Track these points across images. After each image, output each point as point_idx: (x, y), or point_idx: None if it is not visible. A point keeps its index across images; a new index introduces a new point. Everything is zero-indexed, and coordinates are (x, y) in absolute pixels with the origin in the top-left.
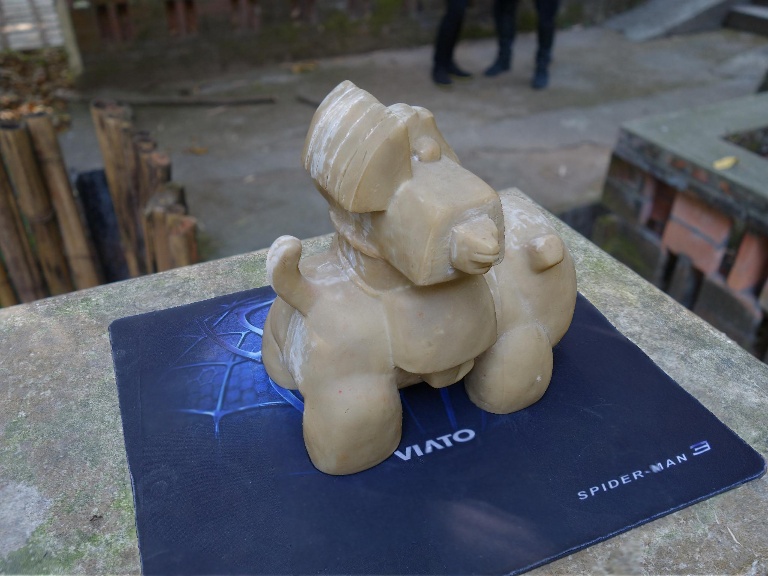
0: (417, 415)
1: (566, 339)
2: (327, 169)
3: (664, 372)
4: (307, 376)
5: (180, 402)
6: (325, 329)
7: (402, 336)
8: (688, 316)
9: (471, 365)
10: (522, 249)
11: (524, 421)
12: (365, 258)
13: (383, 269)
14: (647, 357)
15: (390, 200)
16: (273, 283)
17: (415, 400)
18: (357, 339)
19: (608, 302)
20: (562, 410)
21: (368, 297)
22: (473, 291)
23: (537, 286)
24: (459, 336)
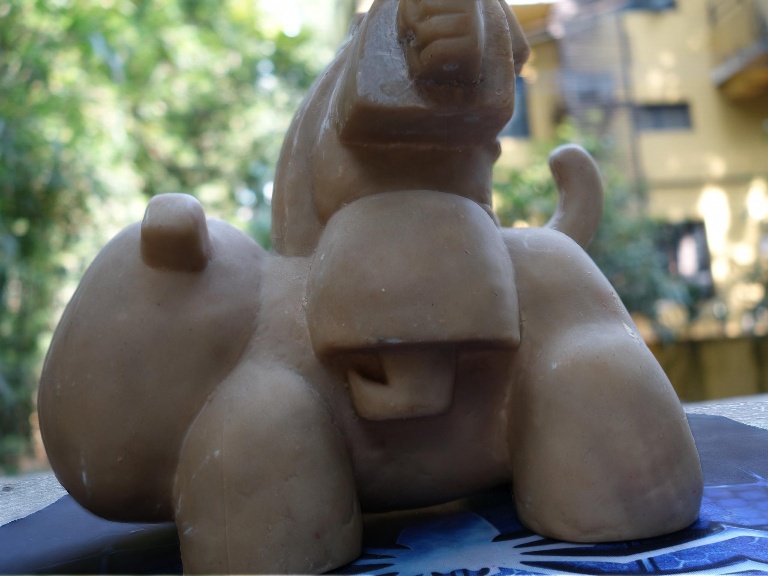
0: None
1: (71, 541)
2: None
3: (36, 512)
4: None
5: None
6: None
7: None
8: None
9: None
10: None
11: None
12: None
13: None
14: (17, 521)
15: None
16: None
17: None
18: None
19: None
20: None
21: None
22: None
23: None
24: None
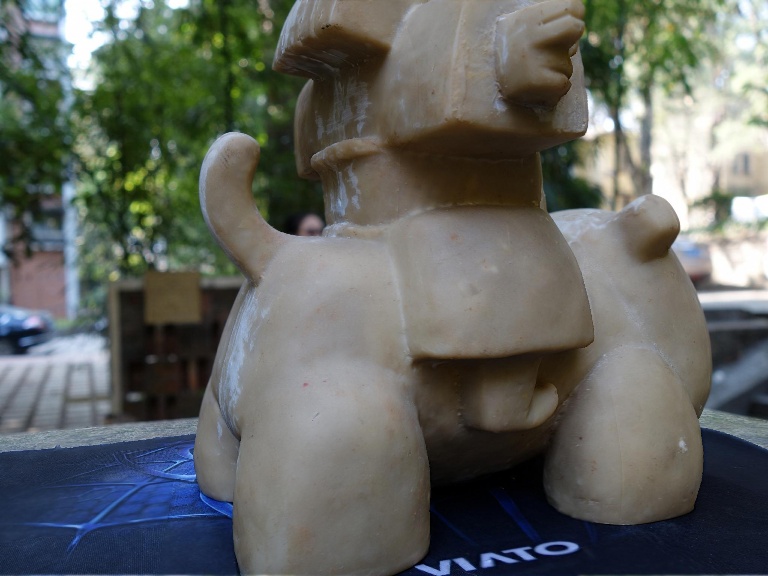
0: (460, 526)
1: (704, 464)
2: (302, 10)
3: None
4: (248, 378)
5: (30, 516)
6: (286, 278)
7: (422, 278)
8: None
9: (553, 399)
10: (610, 225)
11: (672, 532)
12: (359, 168)
13: (388, 173)
14: None
15: (395, 29)
16: (206, 203)
17: (456, 512)
18: (341, 287)
19: (752, 441)
20: (740, 522)
21: (364, 241)
22: (542, 224)
23: (645, 283)
24: (526, 286)
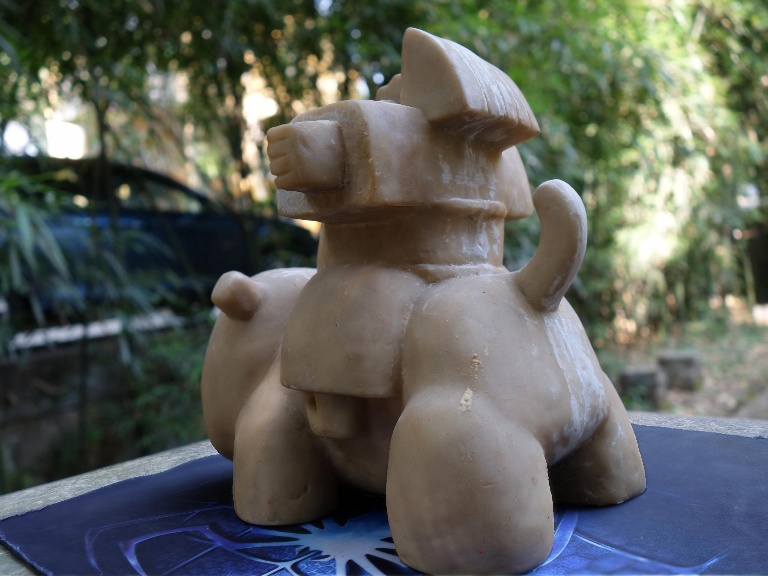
0: None
1: None
2: (512, 97)
3: None
4: (600, 373)
5: None
6: None
7: None
8: (208, 442)
9: None
10: None
11: None
12: None
13: None
14: None
15: None
16: None
17: None
18: None
19: None
20: None
21: None
22: None
23: None
24: None
